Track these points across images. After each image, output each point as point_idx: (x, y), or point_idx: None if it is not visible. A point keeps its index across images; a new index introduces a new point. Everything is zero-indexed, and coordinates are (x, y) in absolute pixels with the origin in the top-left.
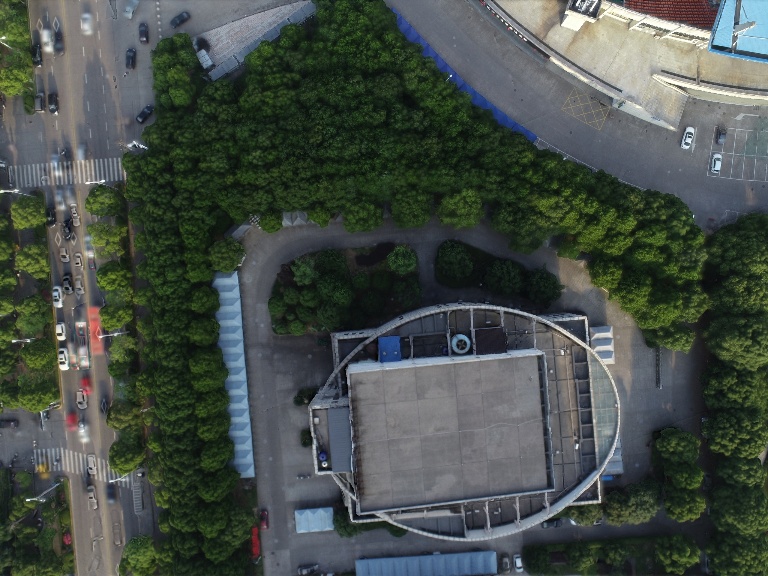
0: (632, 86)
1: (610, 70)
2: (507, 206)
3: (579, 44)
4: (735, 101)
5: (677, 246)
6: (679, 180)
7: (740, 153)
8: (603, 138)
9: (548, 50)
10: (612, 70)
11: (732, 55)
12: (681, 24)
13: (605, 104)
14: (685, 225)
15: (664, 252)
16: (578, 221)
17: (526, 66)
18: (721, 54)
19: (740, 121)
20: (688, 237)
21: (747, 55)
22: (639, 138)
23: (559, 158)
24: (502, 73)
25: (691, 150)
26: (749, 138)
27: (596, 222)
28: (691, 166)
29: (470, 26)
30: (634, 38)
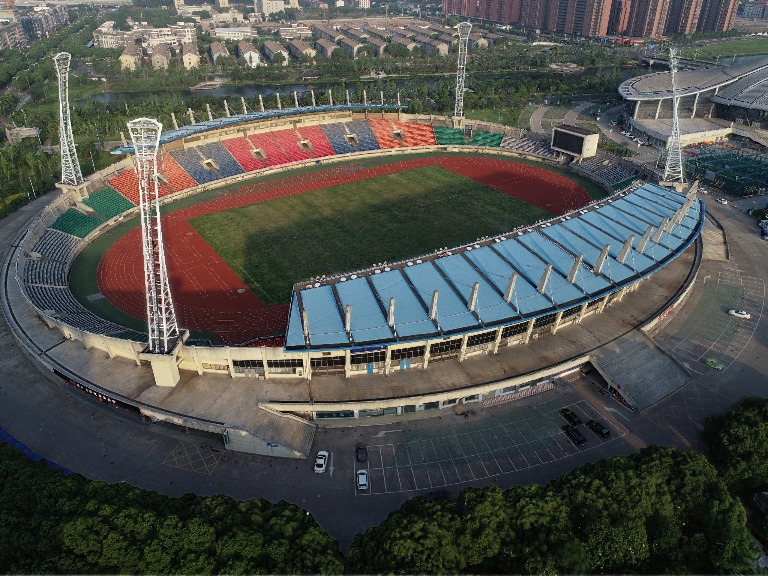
0: (236, 418)
1: (210, 410)
2: (23, 559)
3: (176, 396)
4: (370, 422)
5: (275, 546)
6: (319, 507)
7: (391, 466)
8: (214, 481)
9: (139, 405)
10: (213, 409)
11: (308, 350)
12: (261, 346)
13: (218, 450)
14: (289, 521)
15: (264, 566)
16: (126, 550)
17: (124, 433)
18: (297, 351)
19: (382, 438)
20: (296, 535)
21: (324, 348)
22: (261, 474)
23: (117, 484)
24: (93, 443)
25: (329, 474)
26: (397, 451)
27: (150, 541)
28: (332, 489)
29: (65, 412)
30: (238, 383)
